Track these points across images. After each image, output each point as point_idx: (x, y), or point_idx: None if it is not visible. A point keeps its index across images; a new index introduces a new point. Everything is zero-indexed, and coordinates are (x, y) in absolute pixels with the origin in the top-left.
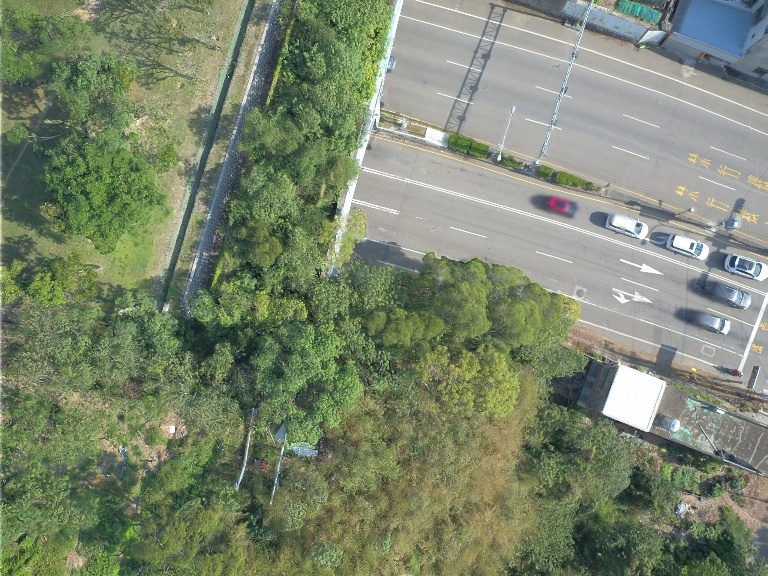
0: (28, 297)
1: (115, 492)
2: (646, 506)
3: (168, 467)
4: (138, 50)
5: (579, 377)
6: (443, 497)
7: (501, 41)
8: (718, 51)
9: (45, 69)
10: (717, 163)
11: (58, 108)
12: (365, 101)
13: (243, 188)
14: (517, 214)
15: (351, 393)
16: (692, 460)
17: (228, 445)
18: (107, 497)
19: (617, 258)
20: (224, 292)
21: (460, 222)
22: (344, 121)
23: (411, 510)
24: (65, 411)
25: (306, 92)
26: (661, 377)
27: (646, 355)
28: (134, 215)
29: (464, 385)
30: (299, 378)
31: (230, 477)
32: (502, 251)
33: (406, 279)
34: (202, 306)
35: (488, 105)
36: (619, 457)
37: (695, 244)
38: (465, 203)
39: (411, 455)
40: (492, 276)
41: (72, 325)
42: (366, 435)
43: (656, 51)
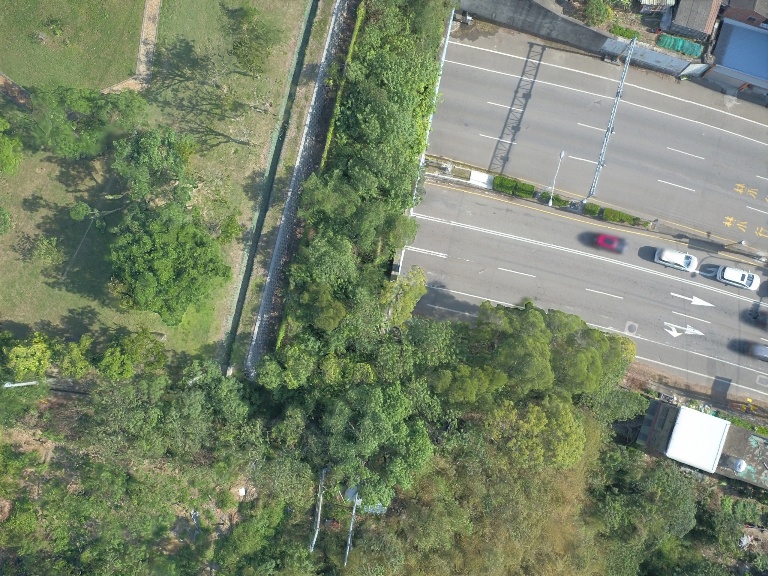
0: (99, 372)
1: (189, 557)
2: (710, 541)
3: (240, 530)
4: (191, 117)
5: (637, 415)
6: (516, 551)
7: (541, 80)
8: (762, 81)
9: (102, 142)
10: (764, 192)
11: (115, 179)
12: (416, 156)
13: (302, 251)
14: (565, 252)
15: (423, 456)
16: (753, 492)
17: (299, 506)
18: (182, 562)
19: (667, 292)
20: (291, 358)
21: (508, 263)
22: (401, 181)
23: (485, 566)
24: (136, 478)
25: (361, 154)
26: (717, 410)
27: (701, 388)
28: (201, 288)
29: (533, 440)
30: (372, 444)
31: (302, 538)
32: (551, 290)
33: (464, 331)
34: (270, 373)
35: (531, 144)
36: (685, 498)
37: (746, 275)
38: (512, 243)
39: (483, 512)
40: (550, 323)
41: (143, 398)
42: (439, 495)
43: (697, 82)
